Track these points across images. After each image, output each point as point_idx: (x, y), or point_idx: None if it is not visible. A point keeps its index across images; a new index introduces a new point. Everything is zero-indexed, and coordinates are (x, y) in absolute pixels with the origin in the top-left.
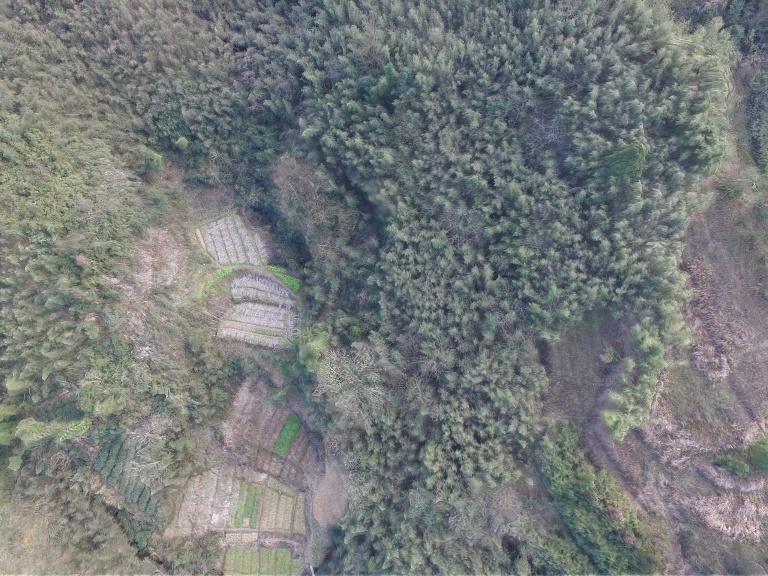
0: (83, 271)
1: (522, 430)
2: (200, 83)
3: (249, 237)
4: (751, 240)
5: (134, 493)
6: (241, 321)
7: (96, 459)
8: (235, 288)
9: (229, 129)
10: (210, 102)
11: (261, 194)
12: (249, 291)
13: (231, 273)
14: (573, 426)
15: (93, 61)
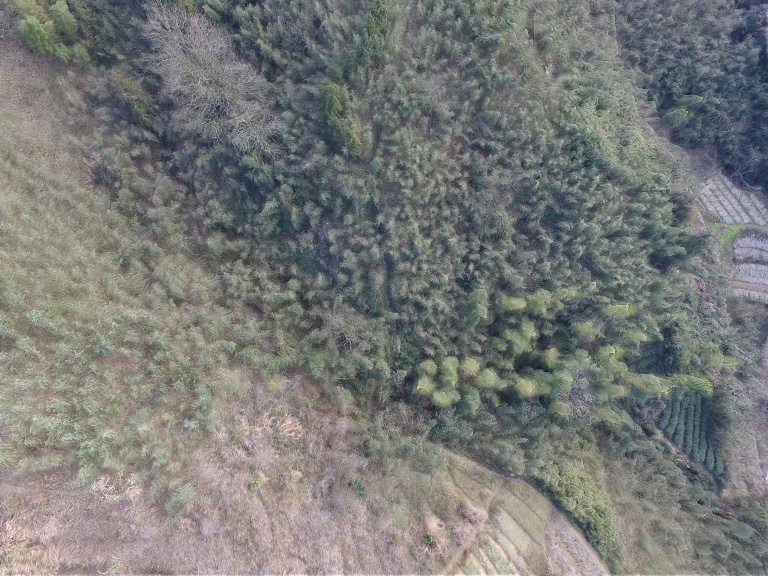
0: (687, 221)
1: None
2: (711, 39)
3: (745, 197)
4: None
5: (701, 452)
6: (749, 282)
7: (659, 417)
8: (738, 248)
9: (734, 86)
10: (720, 58)
11: (759, 153)
12: (753, 251)
13: (737, 233)
14: None
15: (622, 14)
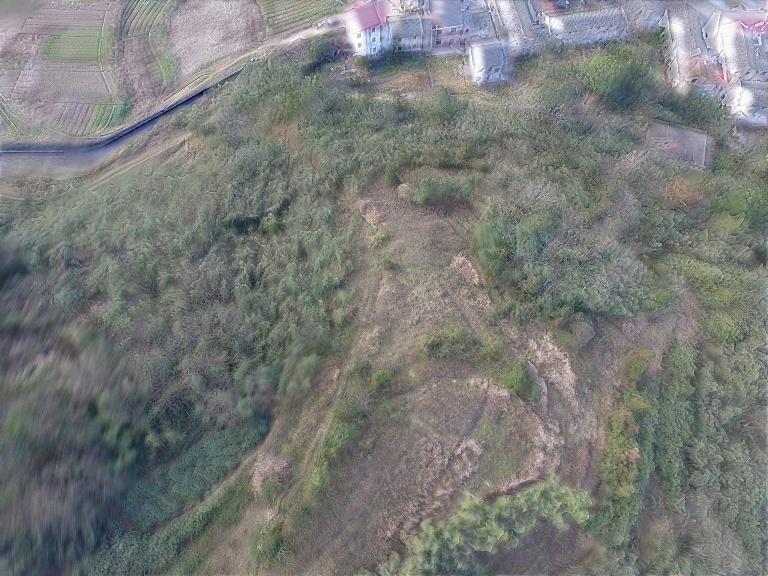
0: None
1: (632, 575)
2: None
3: None
4: (322, 491)
5: None
6: None
7: None
8: None
9: None
10: None
11: None
12: None
13: None
14: (586, 526)
15: None
